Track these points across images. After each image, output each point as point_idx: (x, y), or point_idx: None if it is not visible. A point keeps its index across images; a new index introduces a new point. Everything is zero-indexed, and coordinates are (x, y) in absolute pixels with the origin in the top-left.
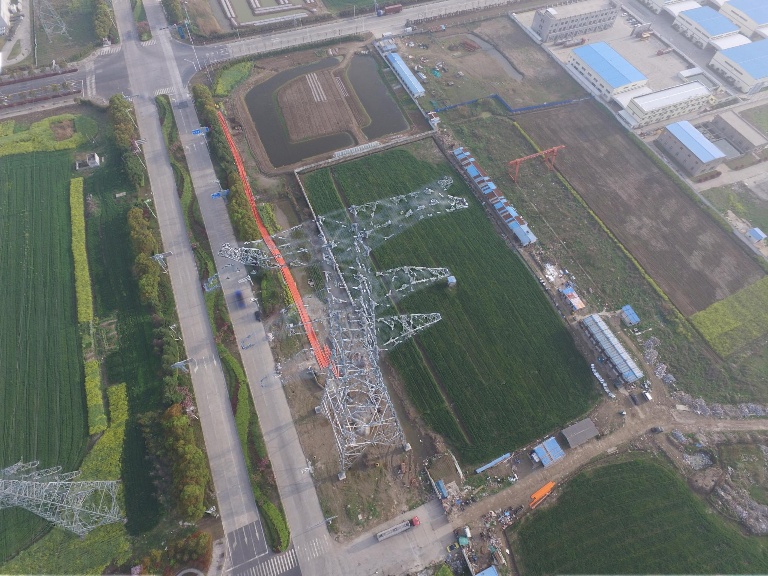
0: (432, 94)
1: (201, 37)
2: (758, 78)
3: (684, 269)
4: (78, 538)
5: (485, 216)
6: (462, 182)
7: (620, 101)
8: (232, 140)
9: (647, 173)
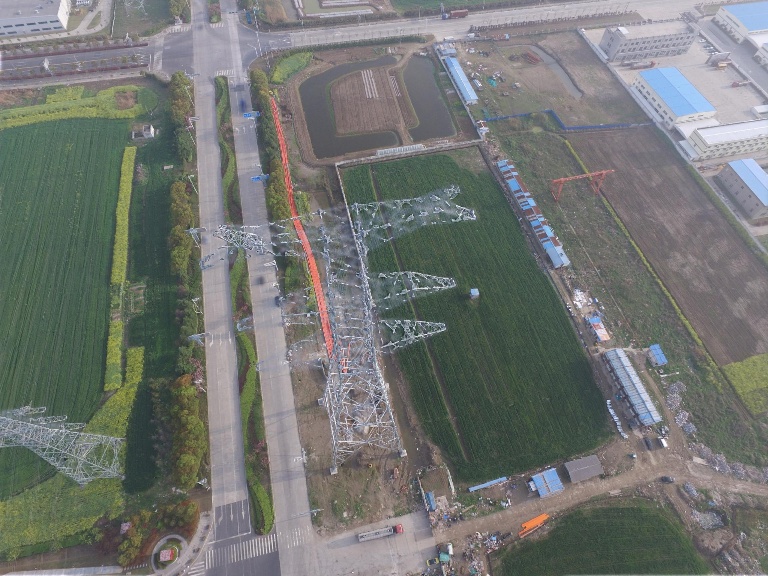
0: (485, 103)
1: (267, 24)
2: None
3: (725, 315)
4: (78, 486)
5: (520, 232)
6: (501, 195)
7: (682, 131)
8: (280, 127)
9: (700, 209)
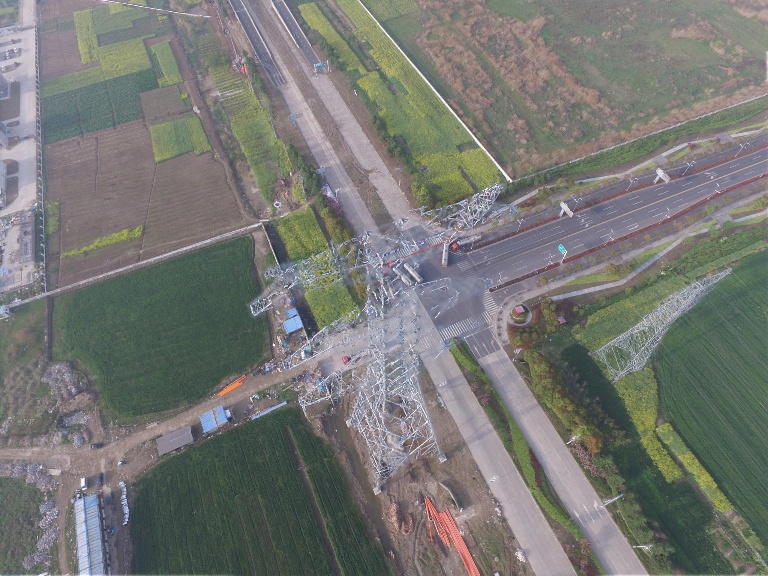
0: None
1: None
2: None
3: None
4: None
5: None
6: None
7: None
8: None
9: None
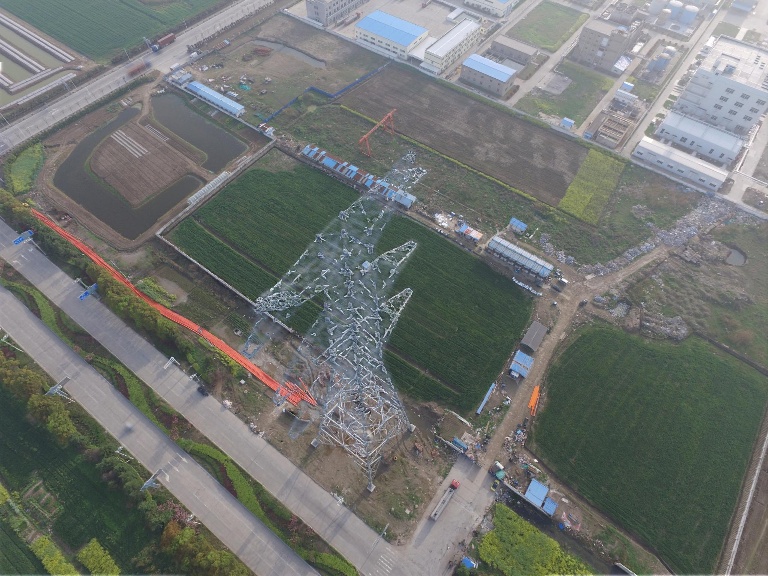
0: (252, 108)
1: None
2: (505, 2)
3: (534, 171)
4: None
5: None
6: (326, 176)
7: (416, 56)
8: (66, 232)
9: (468, 107)
